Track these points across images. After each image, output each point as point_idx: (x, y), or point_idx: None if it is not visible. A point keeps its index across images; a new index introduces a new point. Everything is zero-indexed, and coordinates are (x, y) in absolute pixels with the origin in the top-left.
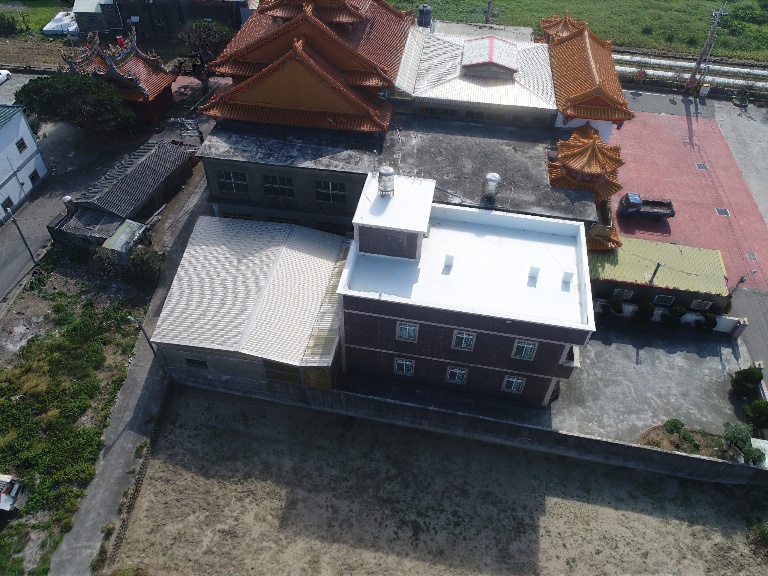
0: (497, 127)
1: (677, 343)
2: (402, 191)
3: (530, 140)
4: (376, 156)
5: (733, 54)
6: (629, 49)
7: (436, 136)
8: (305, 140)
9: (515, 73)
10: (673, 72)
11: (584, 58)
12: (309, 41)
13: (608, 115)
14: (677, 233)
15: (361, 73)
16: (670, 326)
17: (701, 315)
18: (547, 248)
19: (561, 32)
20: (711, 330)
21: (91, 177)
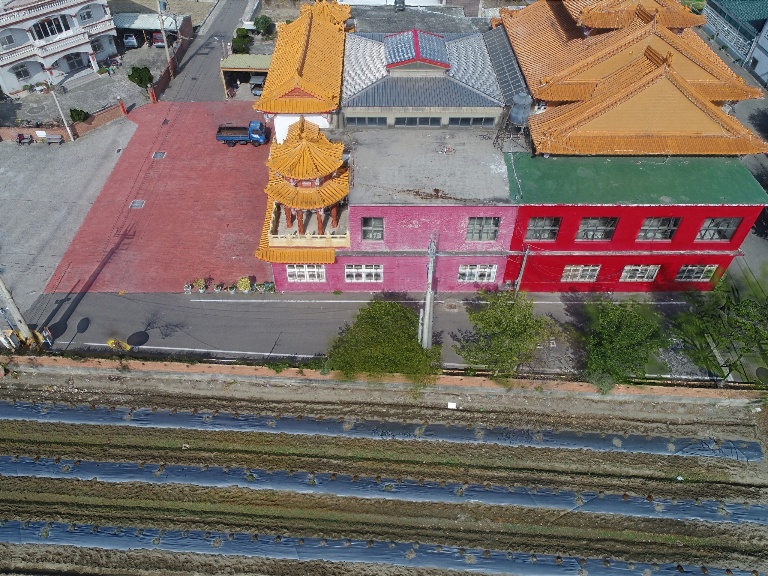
0: None
1: None
2: None
3: None
4: None
5: None
6: None
7: None
8: None
9: None
10: None
11: (309, 55)
12: None
13: None
14: None
15: None
16: None
17: None
18: None
19: None
20: None
21: (765, 127)
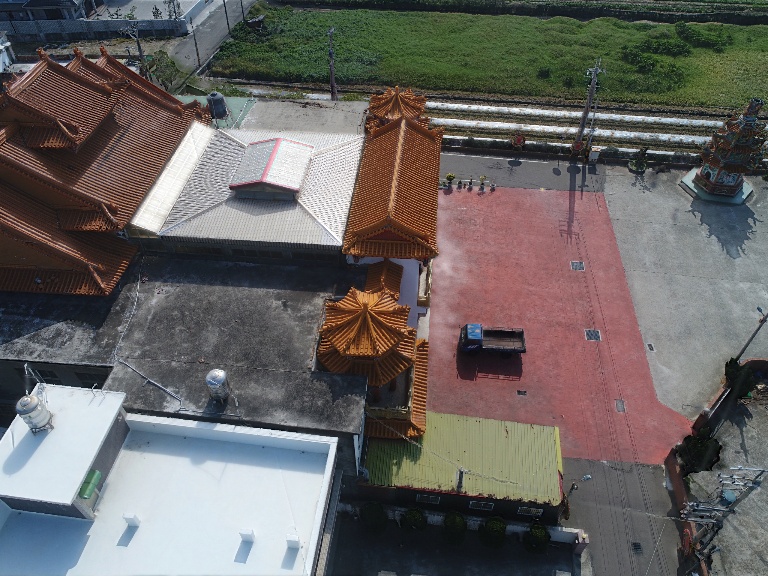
0: (273, 267)
1: (498, 568)
2: (68, 419)
3: (310, 287)
4: (93, 330)
5: (639, 98)
6: (520, 98)
7: (187, 289)
8: (9, 308)
9: (302, 190)
10: (566, 126)
11: (392, 163)
12: (3, 178)
13: (405, 252)
14: (530, 374)
15: (82, 212)
16: (487, 546)
17: (529, 527)
18: (285, 480)
19: (391, 113)
20: (542, 548)
21: None
